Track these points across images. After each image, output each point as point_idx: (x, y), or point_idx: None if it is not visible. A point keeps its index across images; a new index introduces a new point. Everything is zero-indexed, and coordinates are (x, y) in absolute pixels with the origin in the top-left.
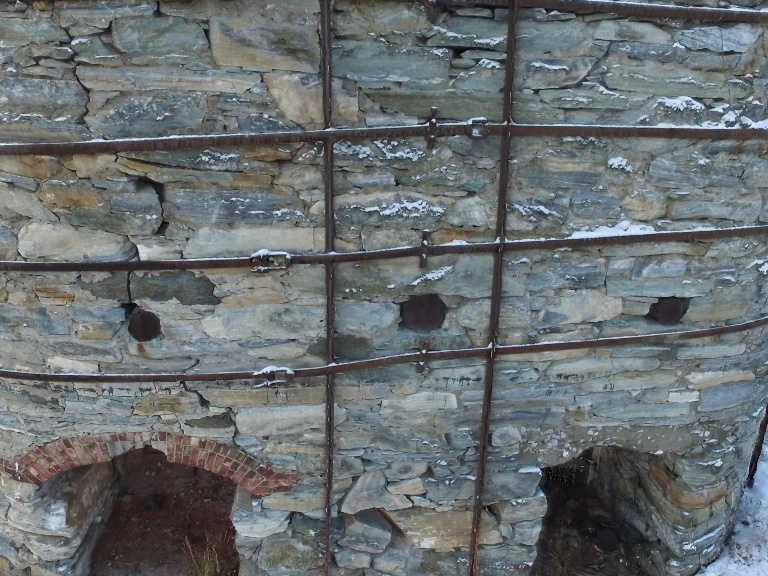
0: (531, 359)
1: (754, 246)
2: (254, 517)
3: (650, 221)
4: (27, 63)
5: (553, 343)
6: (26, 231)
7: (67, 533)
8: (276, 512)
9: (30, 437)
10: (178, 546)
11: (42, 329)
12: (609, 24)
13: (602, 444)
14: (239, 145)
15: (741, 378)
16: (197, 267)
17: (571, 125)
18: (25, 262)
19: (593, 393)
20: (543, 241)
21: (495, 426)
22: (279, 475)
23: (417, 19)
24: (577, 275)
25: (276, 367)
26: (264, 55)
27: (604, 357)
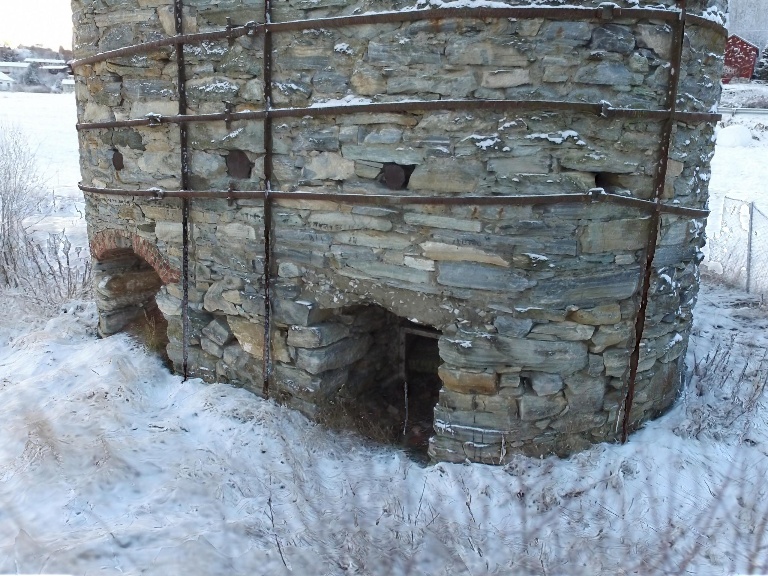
0: (297, 207)
1: (467, 120)
2: (163, 297)
3: (373, 96)
4: None
5: (304, 193)
6: (86, 107)
7: (106, 293)
8: (174, 298)
9: (93, 228)
10: (166, 331)
11: (89, 161)
12: None
13: (367, 300)
14: (146, 51)
15: (488, 260)
16: (133, 125)
17: (304, 20)
18: None
19: (344, 245)
20: (292, 110)
21: (281, 260)
22: (172, 270)
23: None
24: (318, 138)
25: (157, 188)
26: None
27: (347, 212)
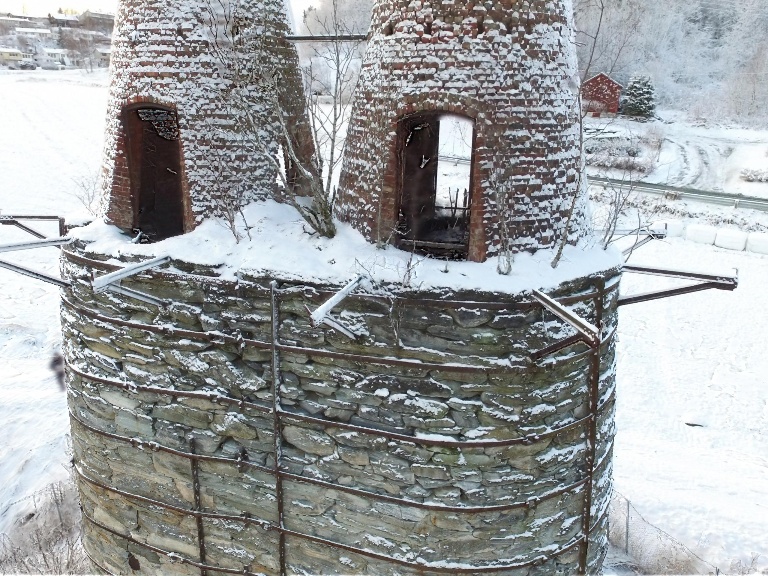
0: None
1: None
2: None
3: None
4: (94, 452)
5: None
6: (96, 509)
7: None
8: None
9: None
10: None
11: (101, 550)
12: (333, 491)
13: None
14: None
15: None
16: (151, 549)
17: (314, 537)
18: (95, 522)
19: None
20: None
21: None
22: None
23: (236, 470)
24: None
25: None
26: (172, 473)
27: None
